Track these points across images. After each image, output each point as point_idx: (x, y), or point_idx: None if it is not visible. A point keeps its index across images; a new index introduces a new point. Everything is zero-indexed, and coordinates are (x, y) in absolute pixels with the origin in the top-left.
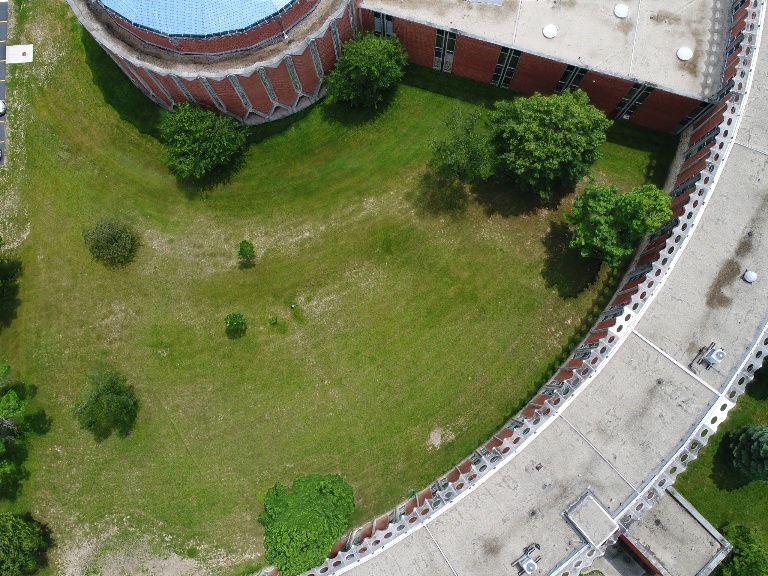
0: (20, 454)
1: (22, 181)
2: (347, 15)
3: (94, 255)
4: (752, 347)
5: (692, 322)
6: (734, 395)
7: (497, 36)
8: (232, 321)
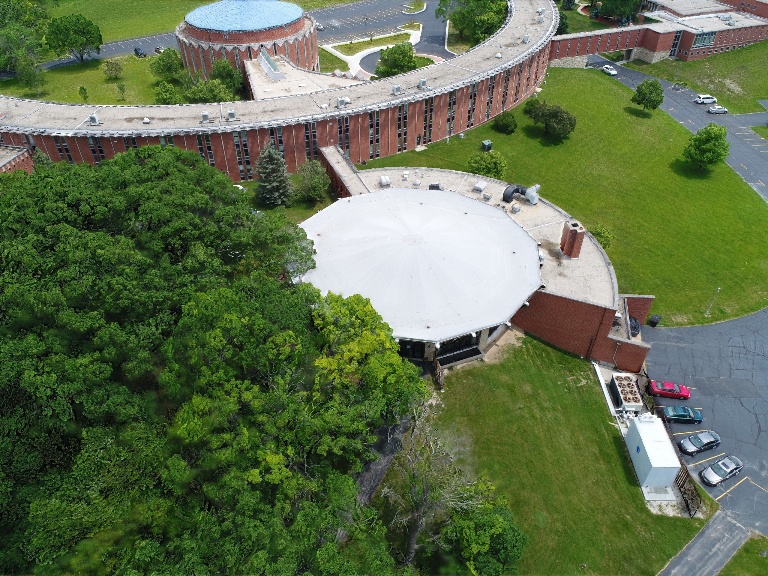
0: (5, 89)
1: (134, 62)
2: (234, 55)
3: (107, 78)
4: (105, 130)
5: (113, 117)
6: (76, 134)
7: (255, 83)
8: (81, 88)
